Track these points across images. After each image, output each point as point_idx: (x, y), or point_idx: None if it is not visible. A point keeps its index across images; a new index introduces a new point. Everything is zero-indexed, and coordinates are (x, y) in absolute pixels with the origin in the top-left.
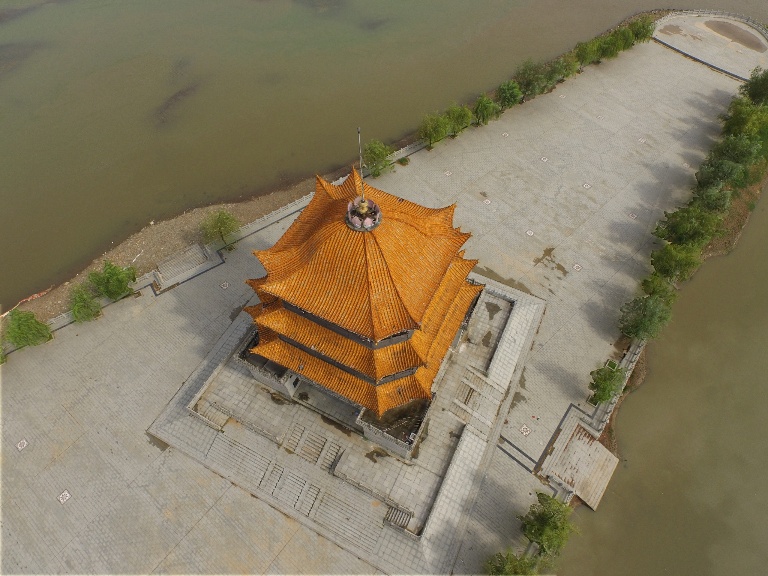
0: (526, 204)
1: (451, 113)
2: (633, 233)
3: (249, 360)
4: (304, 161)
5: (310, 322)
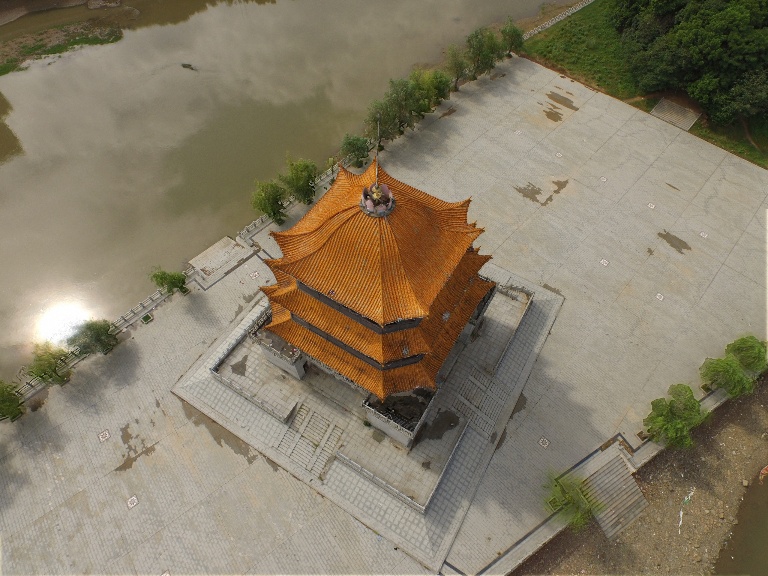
0: (105, 568)
1: None
2: None
3: None
4: None
5: None
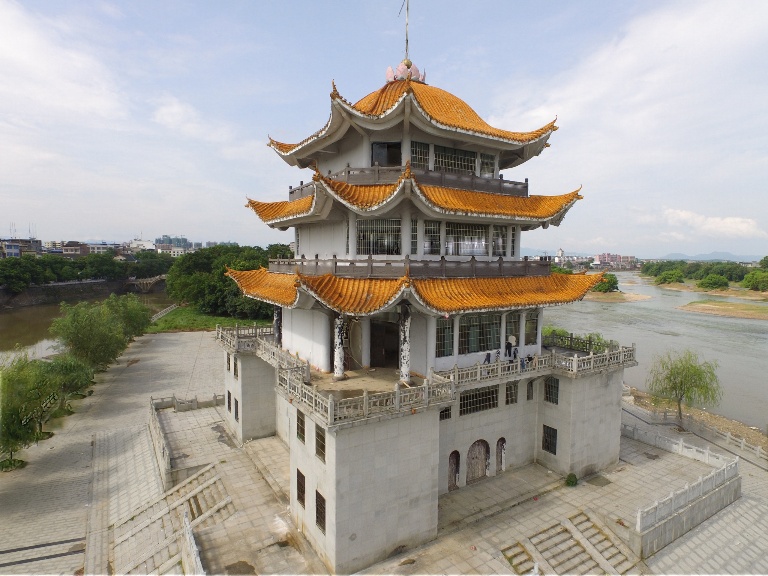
0: None
1: None
2: None
3: None
4: None
5: None
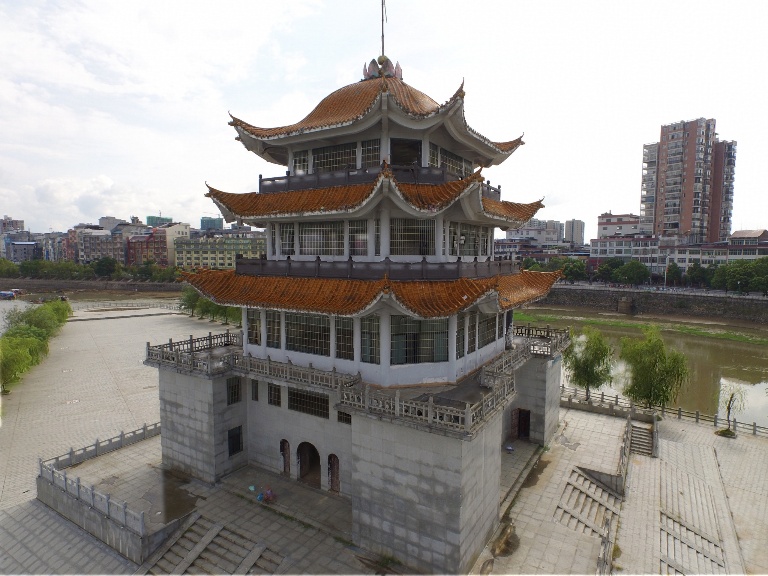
0: None
1: None
2: None
3: None
4: None
5: None
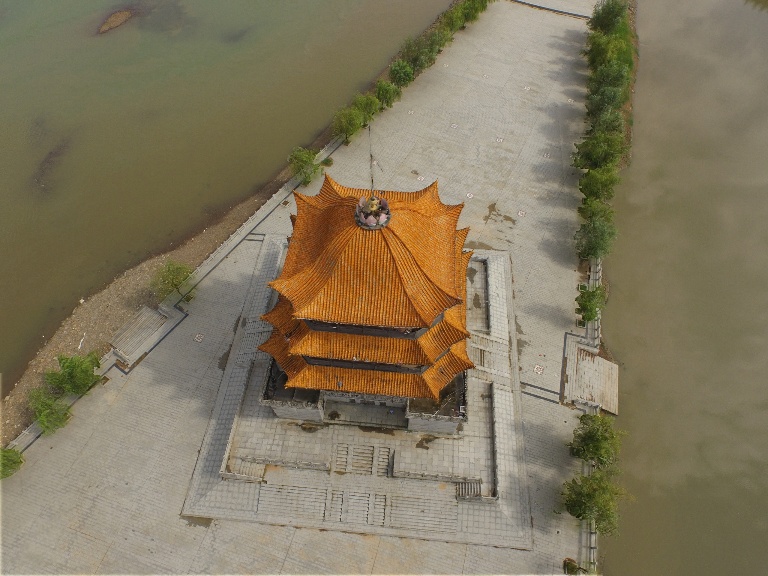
0: (455, 171)
1: (358, 104)
2: (553, 170)
3: (275, 399)
4: (224, 189)
5: (344, 335)
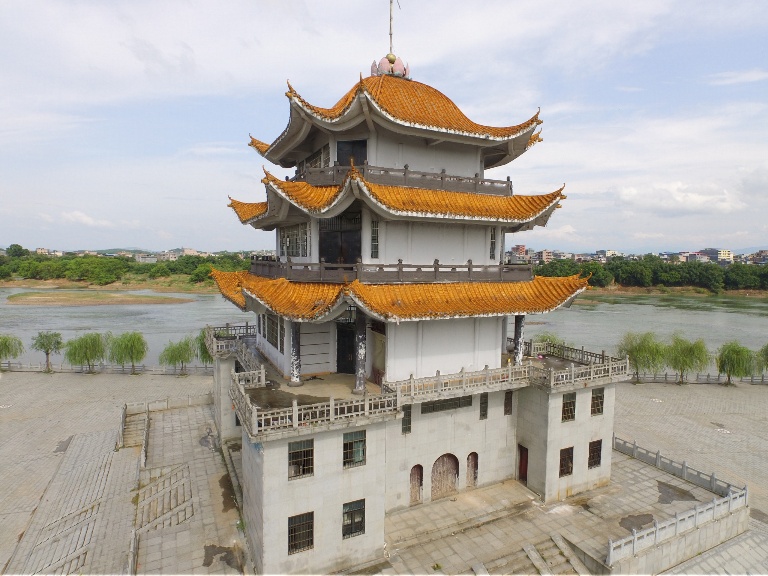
0: None
1: (671, 341)
2: None
3: None
4: None
5: None
